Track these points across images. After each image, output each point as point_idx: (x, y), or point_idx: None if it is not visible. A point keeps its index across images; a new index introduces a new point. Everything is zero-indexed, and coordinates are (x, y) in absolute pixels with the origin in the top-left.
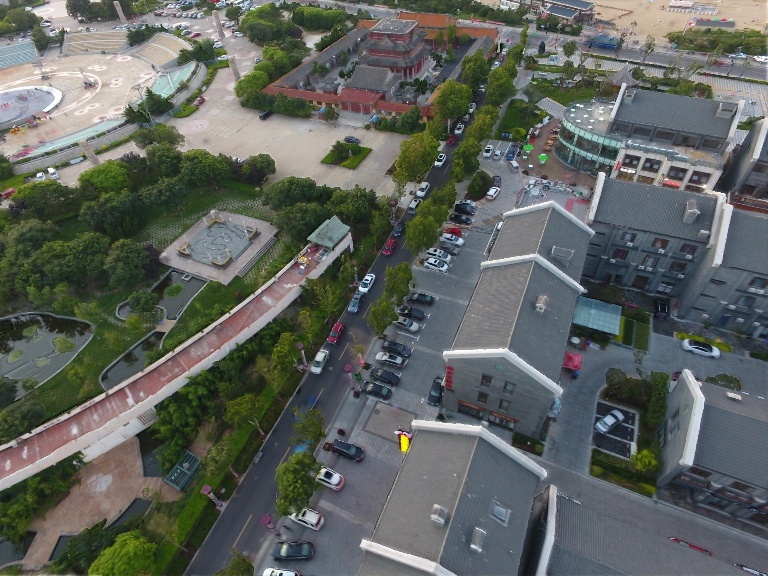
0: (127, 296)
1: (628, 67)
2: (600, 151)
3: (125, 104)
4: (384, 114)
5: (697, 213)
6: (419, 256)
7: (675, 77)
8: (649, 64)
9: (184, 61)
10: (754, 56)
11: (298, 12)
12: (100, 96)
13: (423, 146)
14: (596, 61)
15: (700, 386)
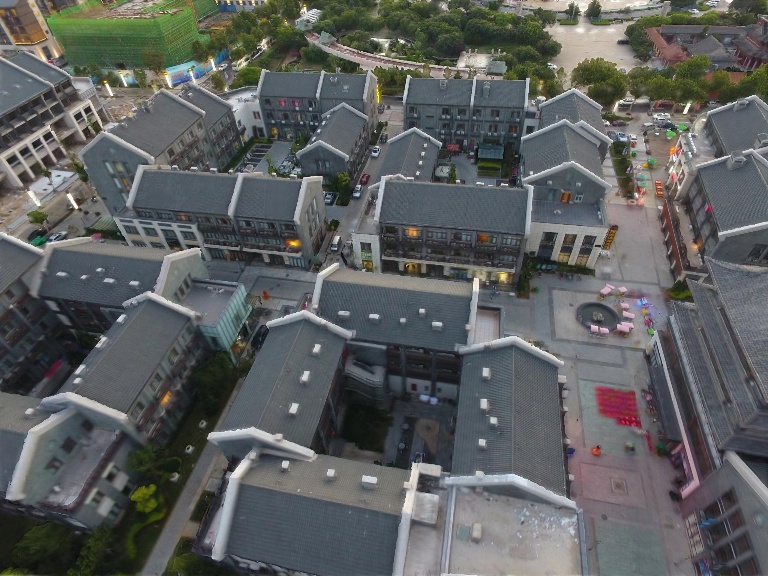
0: (436, 55)
1: None
2: None
3: None
4: None
5: None
6: None
7: None
8: None
9: (661, 0)
10: None
11: None
12: None
13: None
14: None
15: (426, 136)
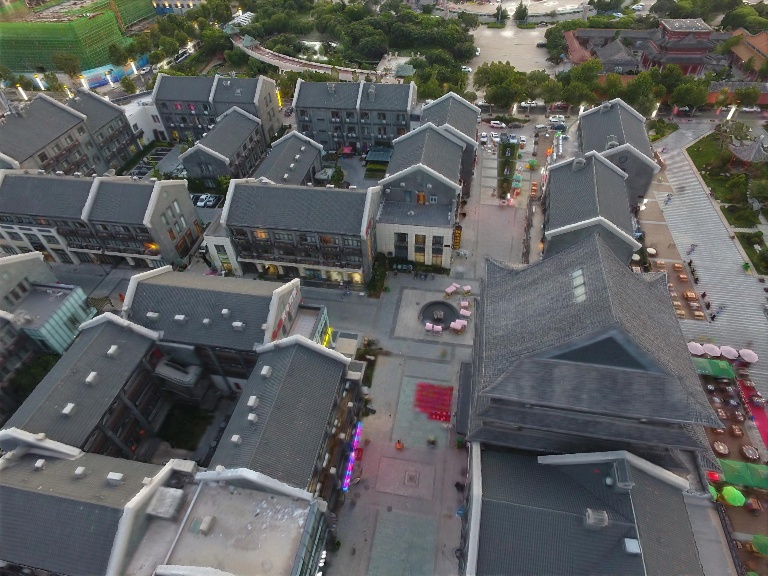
0: (359, 58)
1: None
2: None
3: (499, 4)
4: None
5: None
6: None
7: None
8: None
9: (588, 4)
10: None
11: (735, 9)
12: (529, 5)
13: None
14: None
15: (306, 139)
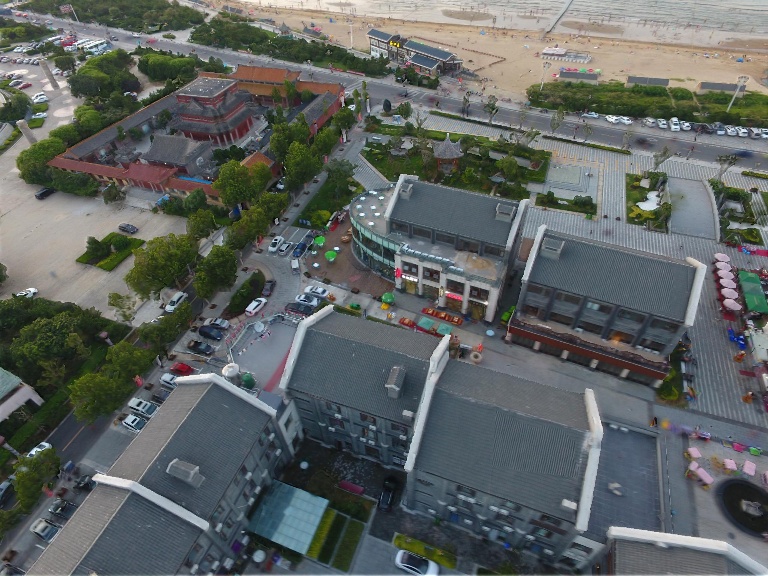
0: None
1: (474, 128)
2: (383, 252)
3: None
4: (178, 193)
5: (396, 389)
6: (116, 413)
7: (515, 143)
8: (496, 125)
9: None
10: (606, 116)
11: (143, 60)
12: None
13: (154, 257)
14: (443, 121)
15: None
